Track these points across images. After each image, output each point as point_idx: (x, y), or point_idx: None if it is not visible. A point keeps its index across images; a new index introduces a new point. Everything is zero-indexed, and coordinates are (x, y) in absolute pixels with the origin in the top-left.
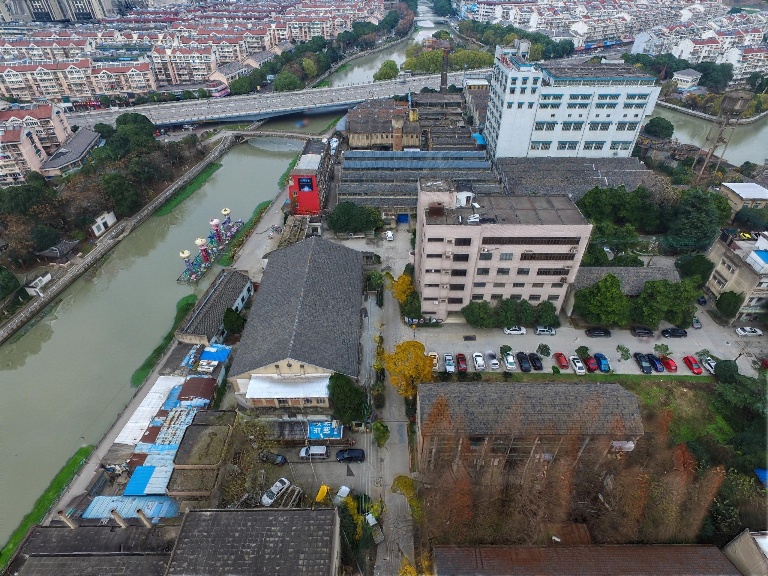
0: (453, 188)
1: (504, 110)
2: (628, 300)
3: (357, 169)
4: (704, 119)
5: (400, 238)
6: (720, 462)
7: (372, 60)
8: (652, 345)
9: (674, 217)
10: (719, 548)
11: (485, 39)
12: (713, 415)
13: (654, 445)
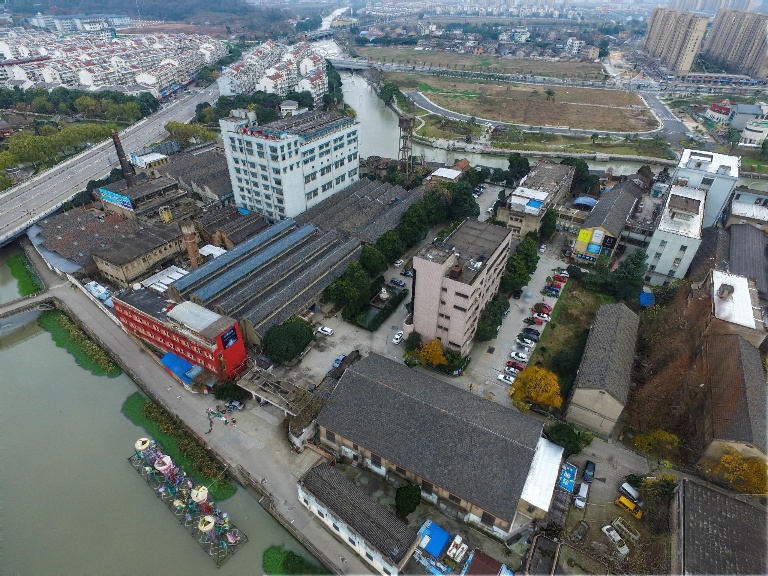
0: (446, 250)
1: (282, 176)
2: None
3: (216, 294)
4: None
5: (333, 327)
6: (636, 310)
7: None
8: (536, 282)
9: (451, 206)
10: (689, 339)
11: (39, 108)
12: None
13: None
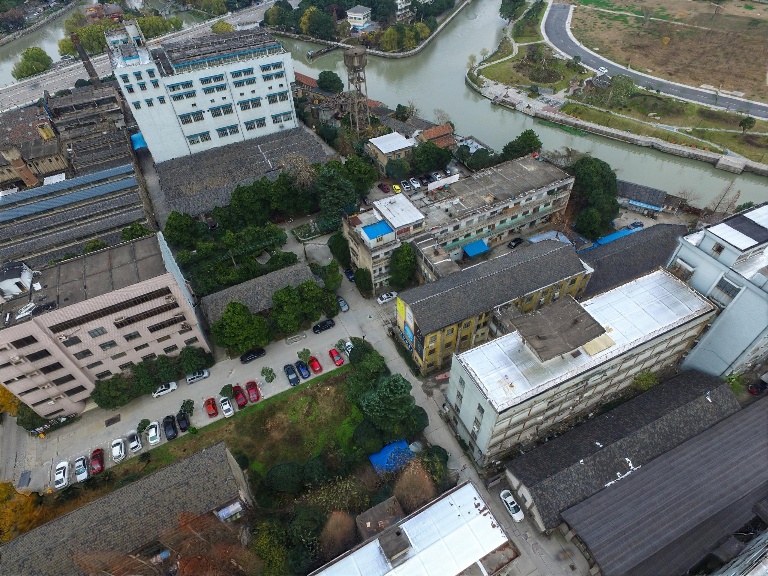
0: None
1: (134, 112)
2: (264, 317)
3: None
4: (380, 56)
5: None
6: (337, 468)
7: (31, 42)
8: None
9: None
10: None
11: None
12: (349, 407)
13: (274, 483)
